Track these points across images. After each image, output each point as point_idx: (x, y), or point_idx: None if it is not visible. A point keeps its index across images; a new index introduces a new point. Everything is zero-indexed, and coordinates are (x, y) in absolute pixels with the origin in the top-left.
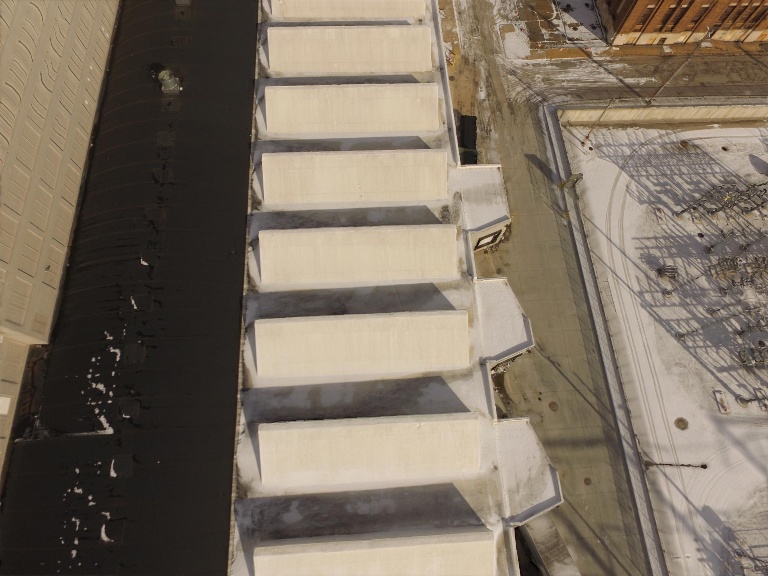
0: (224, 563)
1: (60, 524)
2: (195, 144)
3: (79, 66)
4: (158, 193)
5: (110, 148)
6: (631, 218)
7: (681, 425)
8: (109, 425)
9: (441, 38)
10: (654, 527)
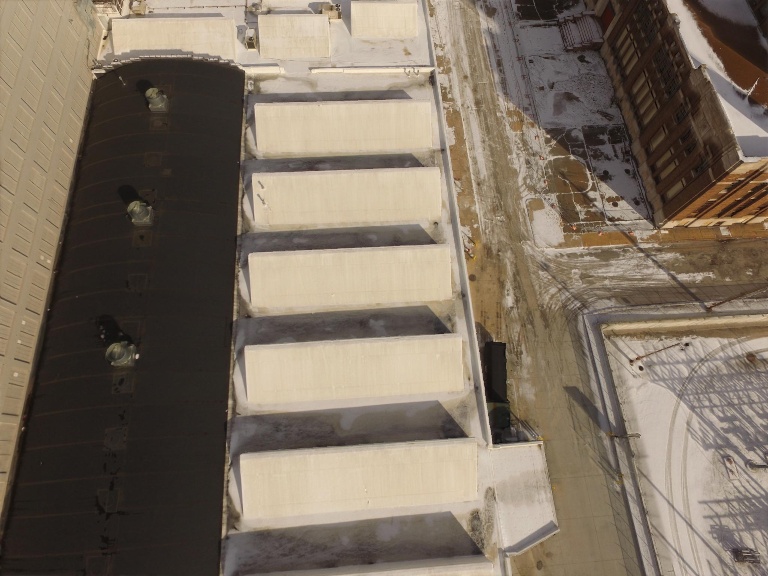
0: None
1: None
2: (153, 444)
3: (4, 336)
4: (102, 531)
5: (44, 446)
6: (696, 471)
7: None
8: None
9: (462, 251)
10: None
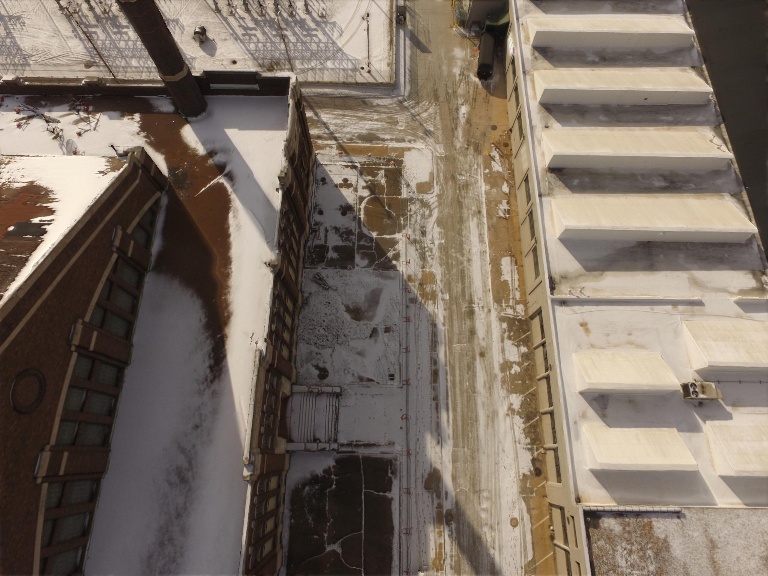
0: None
1: None
2: None
3: None
4: None
5: None
6: (348, 12)
7: None
8: None
9: None
10: None
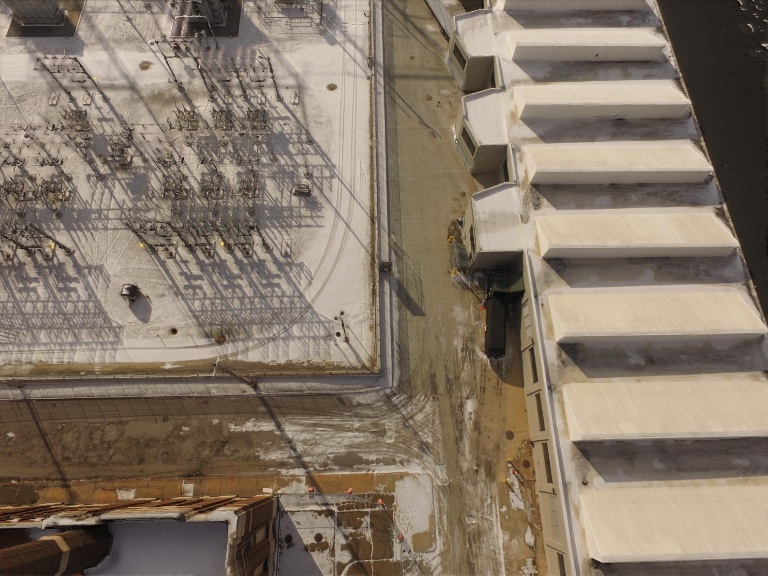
0: (660, 1)
1: (767, 9)
2: None
3: None
4: None
5: None
6: (318, 247)
7: (332, 87)
8: (766, 48)
9: None
10: (375, 33)
